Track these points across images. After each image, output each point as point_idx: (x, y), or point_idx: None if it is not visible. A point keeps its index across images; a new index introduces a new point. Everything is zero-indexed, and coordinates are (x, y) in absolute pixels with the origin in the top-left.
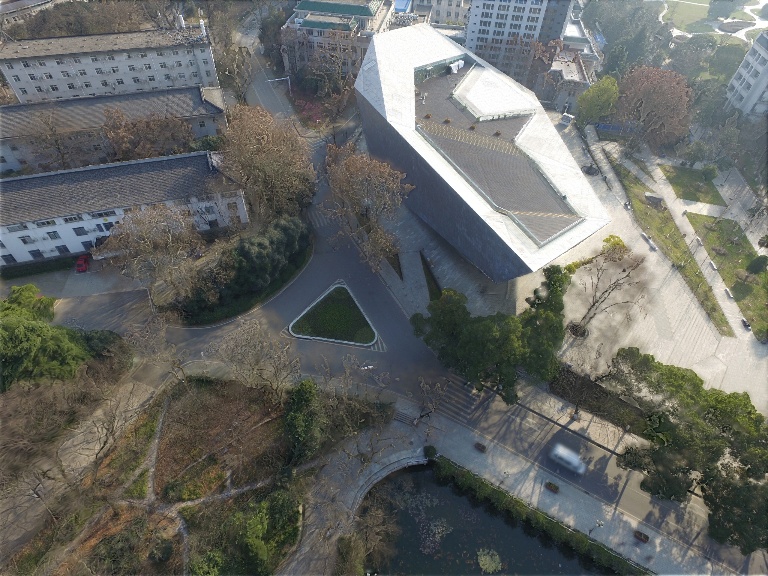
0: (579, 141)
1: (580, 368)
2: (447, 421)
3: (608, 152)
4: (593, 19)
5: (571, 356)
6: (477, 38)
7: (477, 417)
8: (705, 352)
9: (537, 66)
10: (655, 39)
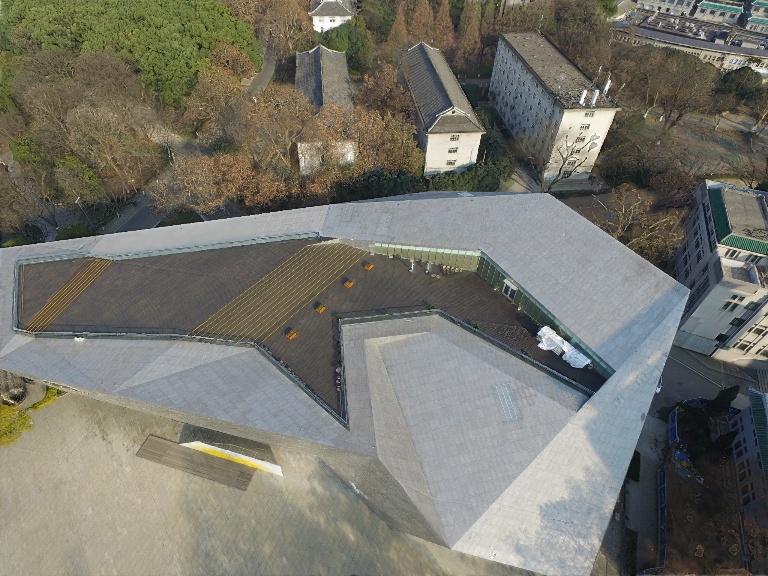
0: None
1: None
2: None
3: None
4: None
5: None
6: None
7: None
8: None
9: None
10: None
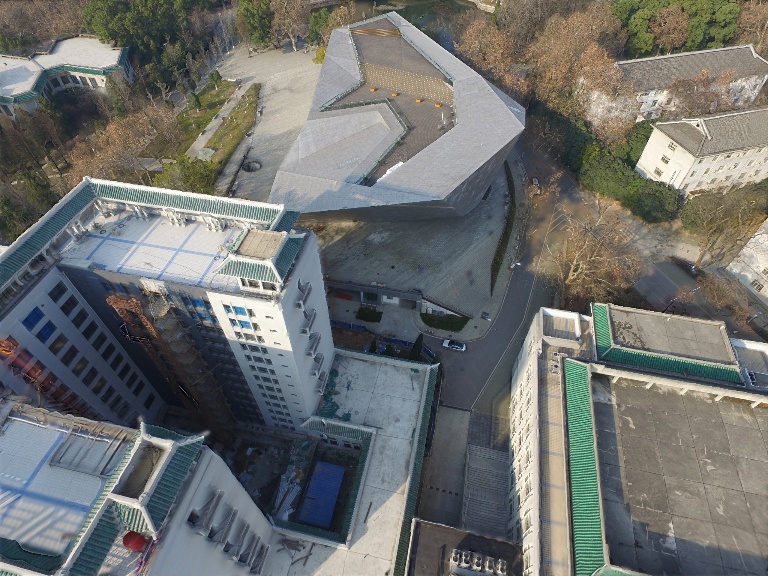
0: None
1: None
2: None
3: None
4: None
5: None
6: None
7: None
8: None
9: None
10: None
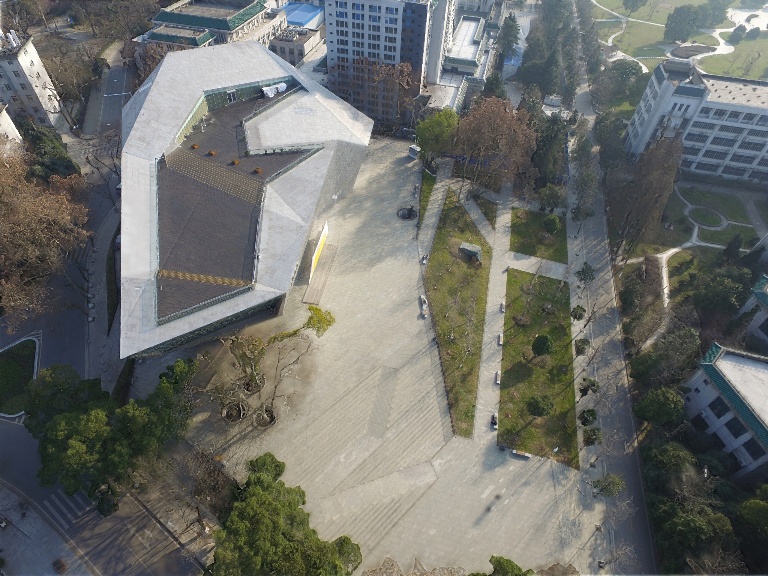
0: (417, 178)
1: (235, 469)
2: (43, 525)
3: (453, 191)
4: (508, 39)
5: (235, 451)
6: (337, 57)
7: (84, 523)
8: (418, 456)
9: (405, 90)
10: (588, 63)
